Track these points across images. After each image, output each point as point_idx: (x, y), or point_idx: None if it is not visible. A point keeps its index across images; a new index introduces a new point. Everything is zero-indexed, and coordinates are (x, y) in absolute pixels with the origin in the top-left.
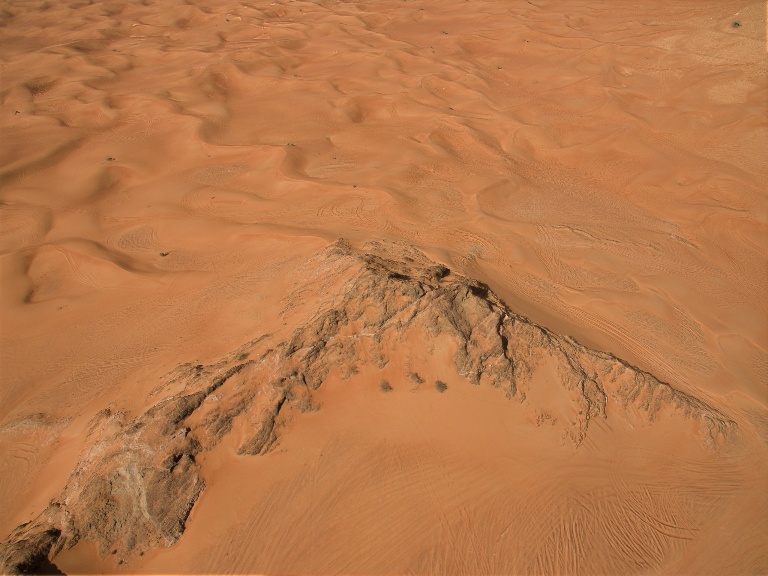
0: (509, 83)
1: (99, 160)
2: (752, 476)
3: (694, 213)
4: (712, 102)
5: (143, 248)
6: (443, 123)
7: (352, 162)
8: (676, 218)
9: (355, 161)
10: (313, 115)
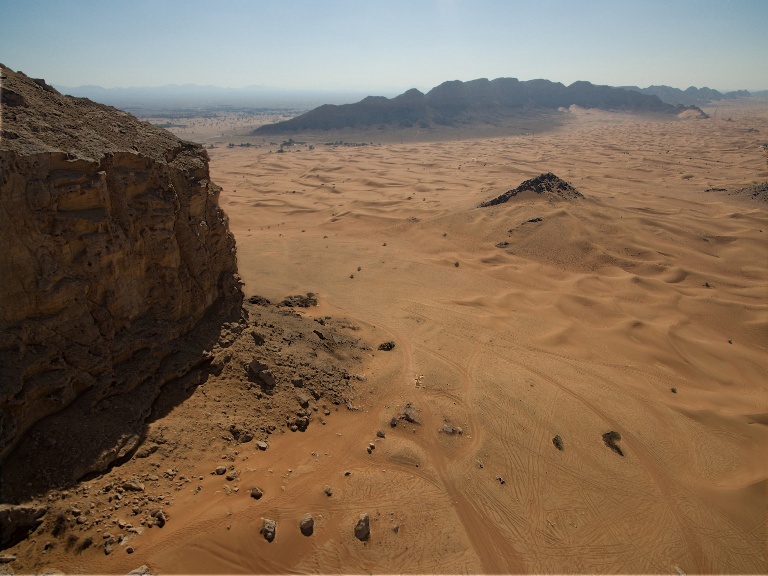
0: (765, 350)
1: (764, 230)
2: None
3: (503, 255)
4: (538, 316)
5: (652, 214)
6: (679, 266)
7: (658, 235)
8: None
9: (659, 236)
10: (767, 265)
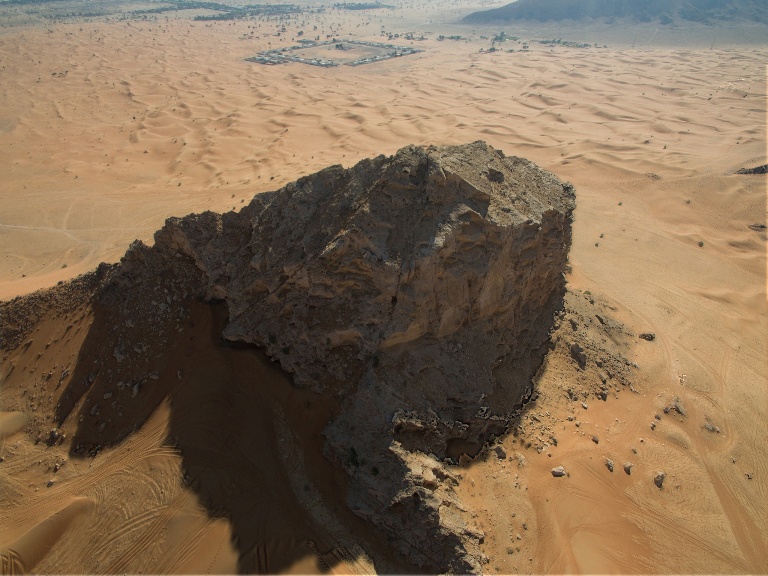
0: None
1: None
2: (729, 169)
3: None
4: None
5: None
6: None
7: None
8: (763, 242)
9: None
10: None
